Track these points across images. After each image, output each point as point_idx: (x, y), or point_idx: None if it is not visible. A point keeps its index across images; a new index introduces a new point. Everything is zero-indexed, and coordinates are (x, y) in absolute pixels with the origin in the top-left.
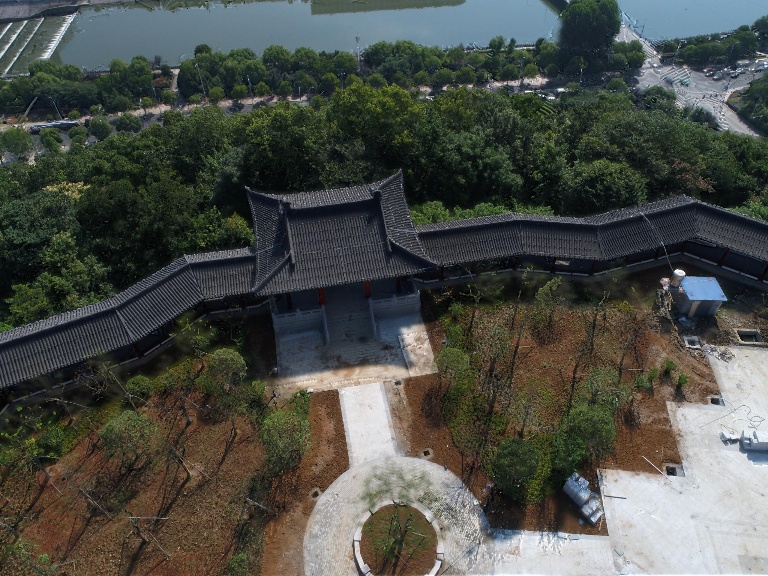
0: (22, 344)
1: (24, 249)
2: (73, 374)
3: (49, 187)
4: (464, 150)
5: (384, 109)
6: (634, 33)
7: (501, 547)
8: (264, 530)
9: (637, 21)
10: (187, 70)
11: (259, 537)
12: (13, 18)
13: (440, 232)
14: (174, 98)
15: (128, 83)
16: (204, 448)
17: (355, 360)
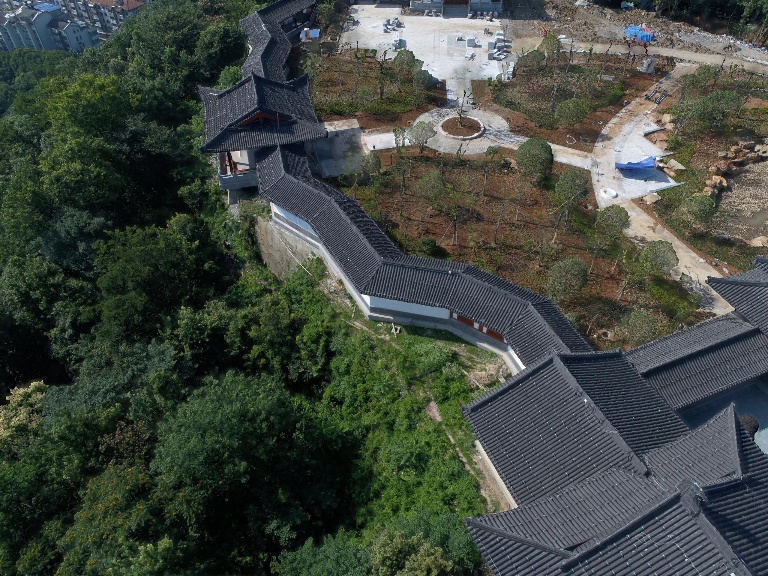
0: None
1: None
2: None
3: None
4: (148, 88)
5: None
6: None
7: None
8: None
9: None
10: None
11: None
12: None
13: None
14: None
15: None
16: None
17: (347, 146)
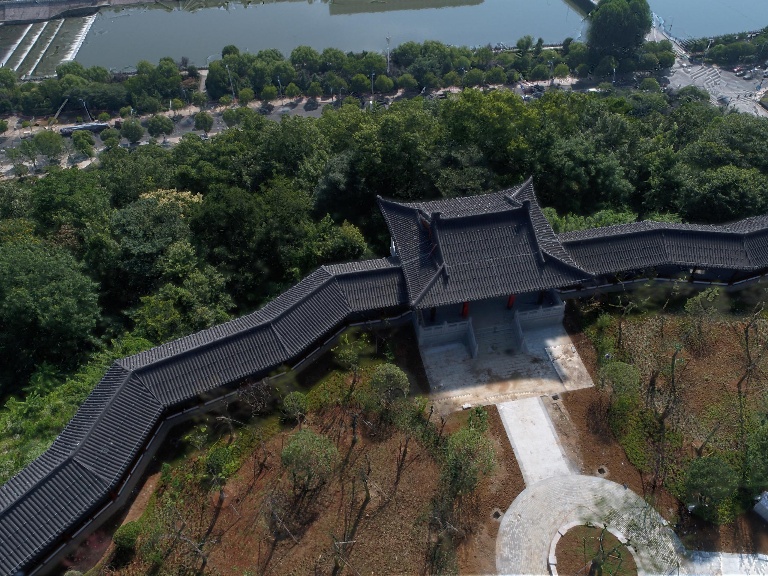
0: (182, 360)
1: (137, 259)
2: (224, 390)
3: (145, 194)
4: (577, 156)
5: (500, 114)
6: (664, 32)
7: (702, 570)
8: (456, 553)
9: (665, 20)
10: (216, 71)
11: (453, 561)
12: (33, 19)
13: (583, 241)
14: (204, 100)
15: (157, 85)
16: (376, 467)
17: (506, 374)
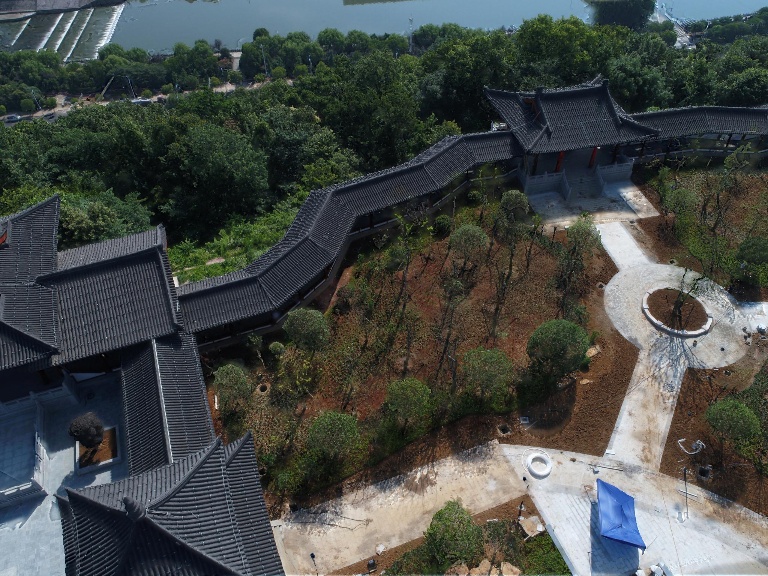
0: (364, 187)
1: None
2: (386, 217)
3: None
4: (628, 68)
5: (568, 33)
6: (666, 14)
7: (750, 311)
8: None
9: (665, 4)
10: (251, 51)
11: (577, 305)
12: (64, 9)
13: (646, 116)
14: (240, 77)
15: (195, 64)
16: None
17: (593, 209)
